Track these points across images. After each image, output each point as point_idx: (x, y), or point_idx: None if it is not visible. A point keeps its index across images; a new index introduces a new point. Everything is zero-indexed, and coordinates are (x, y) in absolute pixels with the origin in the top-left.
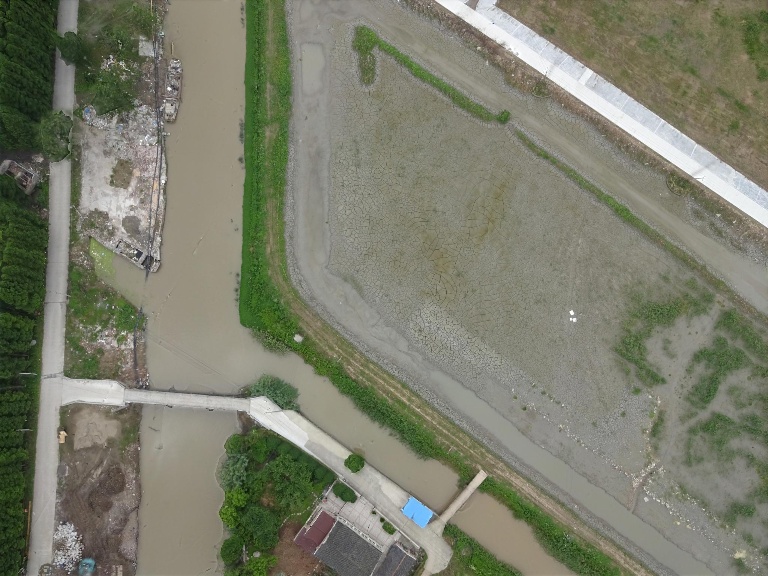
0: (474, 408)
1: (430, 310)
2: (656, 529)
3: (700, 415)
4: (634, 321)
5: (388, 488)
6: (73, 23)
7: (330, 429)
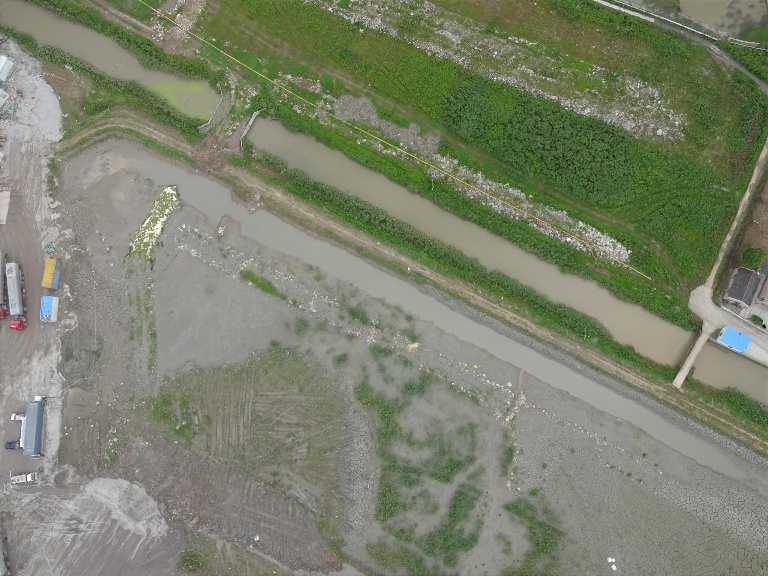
0: (695, 447)
1: (765, 545)
2: (496, 358)
3: (464, 478)
4: (548, 570)
5: (762, 356)
6: None
7: None
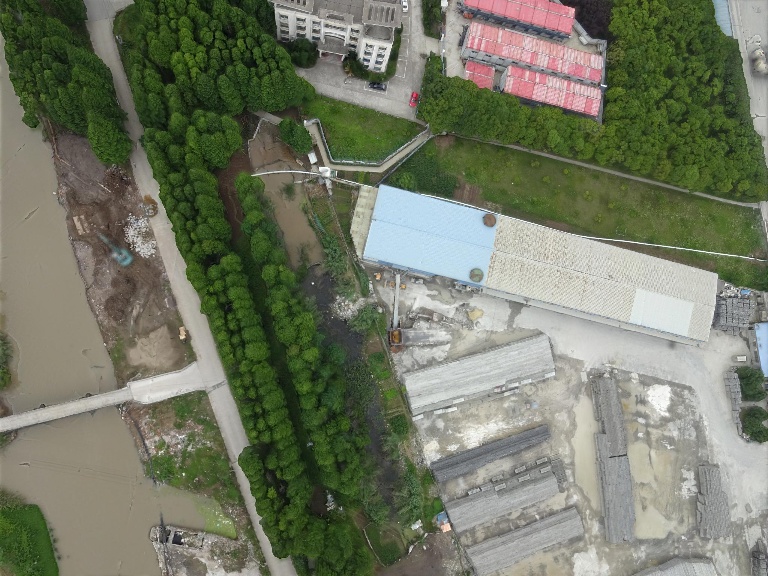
0: None
1: None
2: None
3: None
4: None
5: None
6: None
7: None
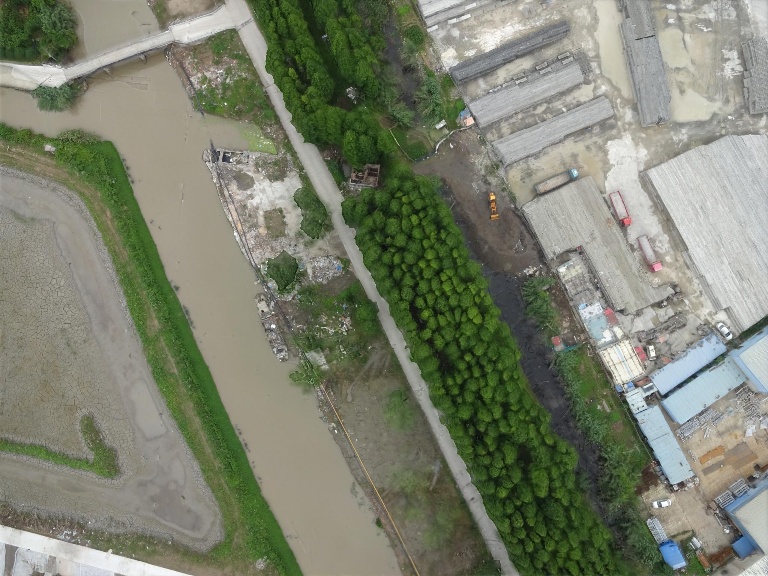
0: None
1: None
2: None
3: None
4: None
5: None
6: (399, 351)
7: (0, 91)
